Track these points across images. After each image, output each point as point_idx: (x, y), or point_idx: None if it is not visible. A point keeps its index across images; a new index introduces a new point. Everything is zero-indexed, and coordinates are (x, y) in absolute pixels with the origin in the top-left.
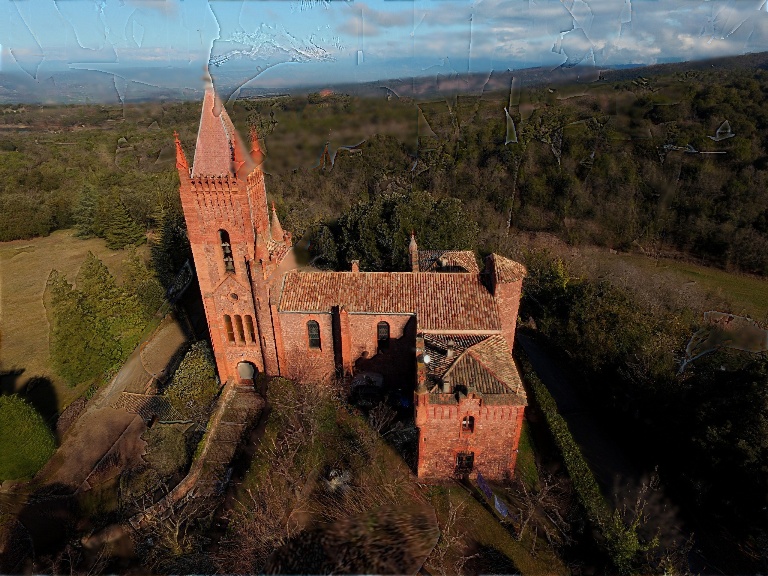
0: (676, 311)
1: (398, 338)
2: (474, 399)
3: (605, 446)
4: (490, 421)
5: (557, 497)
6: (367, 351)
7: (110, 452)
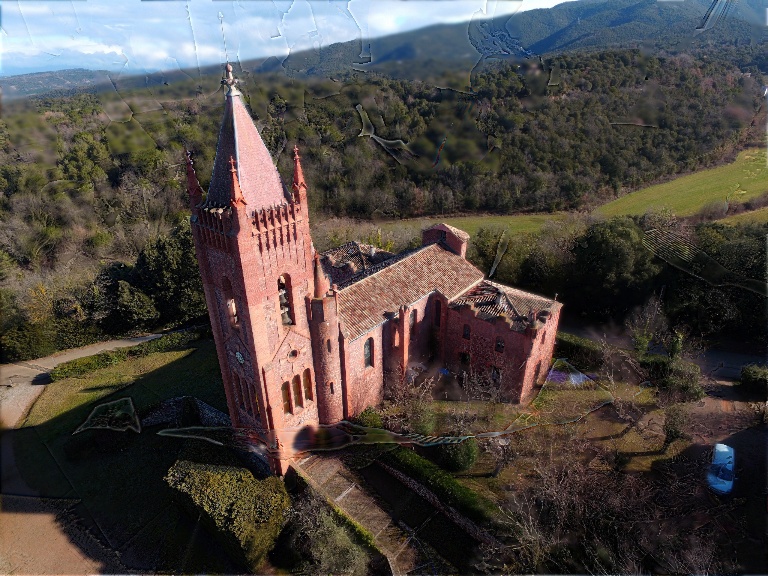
0: None
1: (422, 320)
2: None
3: None
4: None
5: (573, 360)
6: None
7: None
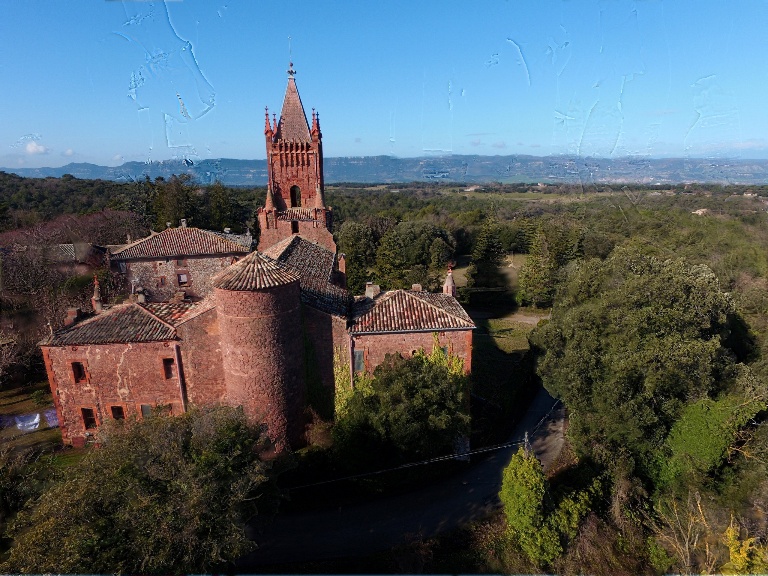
0: None
1: None
2: None
3: None
4: None
5: None
6: None
7: None
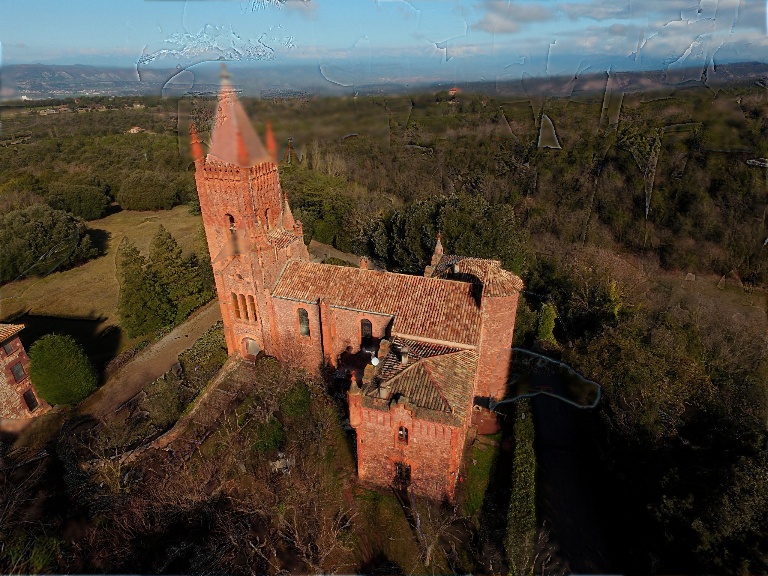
0: (757, 361)
1: (380, 338)
2: (406, 410)
3: (577, 493)
4: (424, 436)
5: (491, 533)
6: (351, 346)
7: (135, 398)
